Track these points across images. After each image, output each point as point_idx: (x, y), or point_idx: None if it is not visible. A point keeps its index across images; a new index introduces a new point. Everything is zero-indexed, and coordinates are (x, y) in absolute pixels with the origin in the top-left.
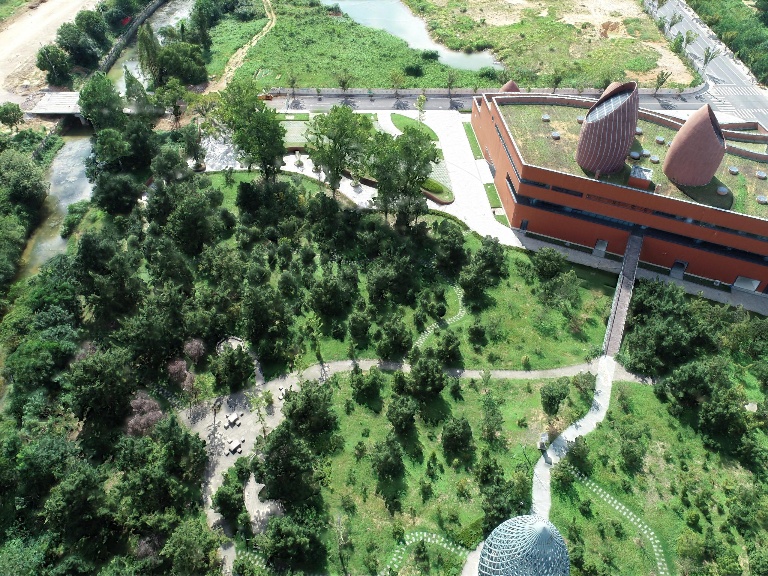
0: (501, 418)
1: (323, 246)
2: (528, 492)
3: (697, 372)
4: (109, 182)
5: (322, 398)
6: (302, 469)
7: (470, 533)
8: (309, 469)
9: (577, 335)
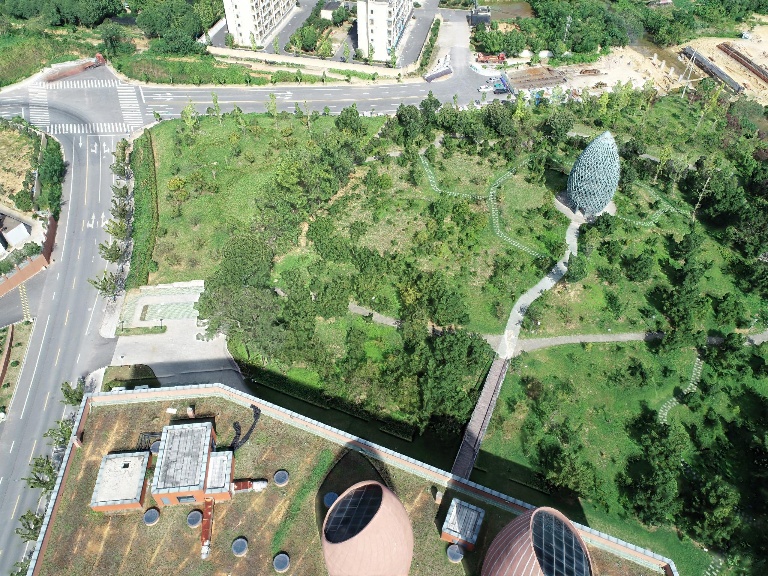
0: (611, 271)
1: None
2: None
3: (448, 296)
4: None
5: None
6: None
7: (617, 221)
8: None
9: None
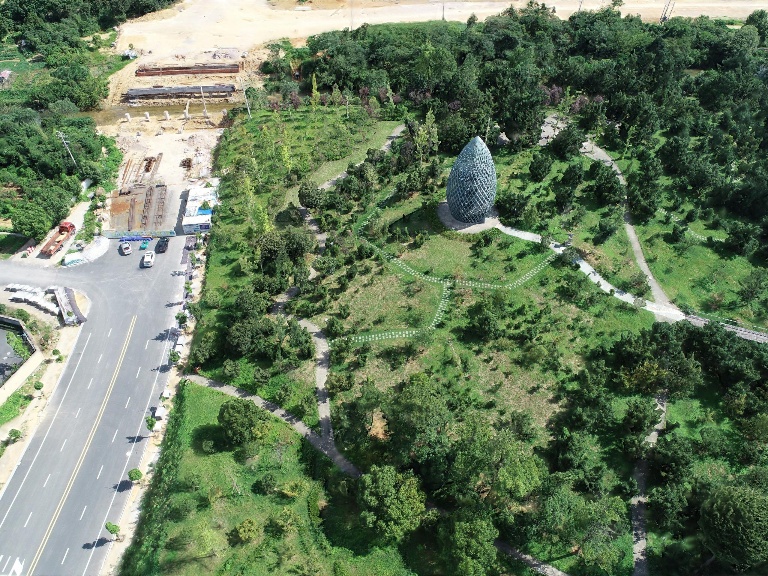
0: (582, 215)
1: (741, 164)
2: (526, 220)
3: None
4: (740, 57)
5: (575, 142)
6: (518, 118)
7: None
8: (519, 123)
9: (706, 305)
